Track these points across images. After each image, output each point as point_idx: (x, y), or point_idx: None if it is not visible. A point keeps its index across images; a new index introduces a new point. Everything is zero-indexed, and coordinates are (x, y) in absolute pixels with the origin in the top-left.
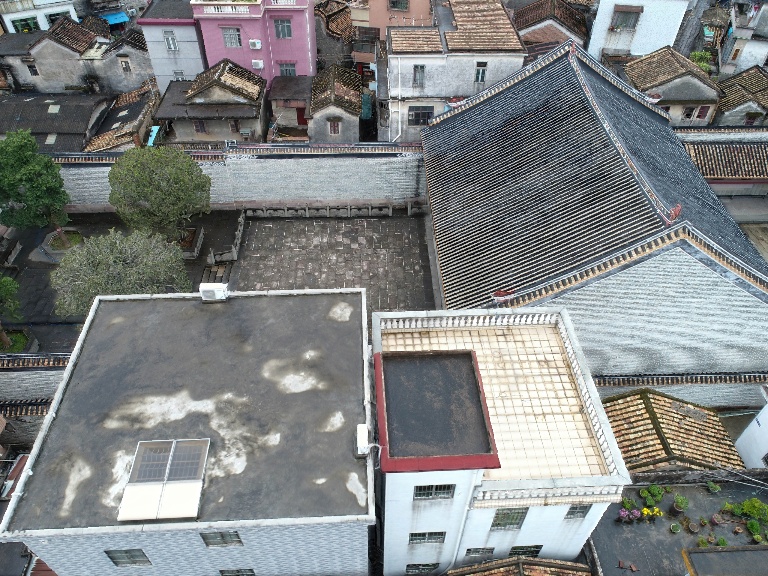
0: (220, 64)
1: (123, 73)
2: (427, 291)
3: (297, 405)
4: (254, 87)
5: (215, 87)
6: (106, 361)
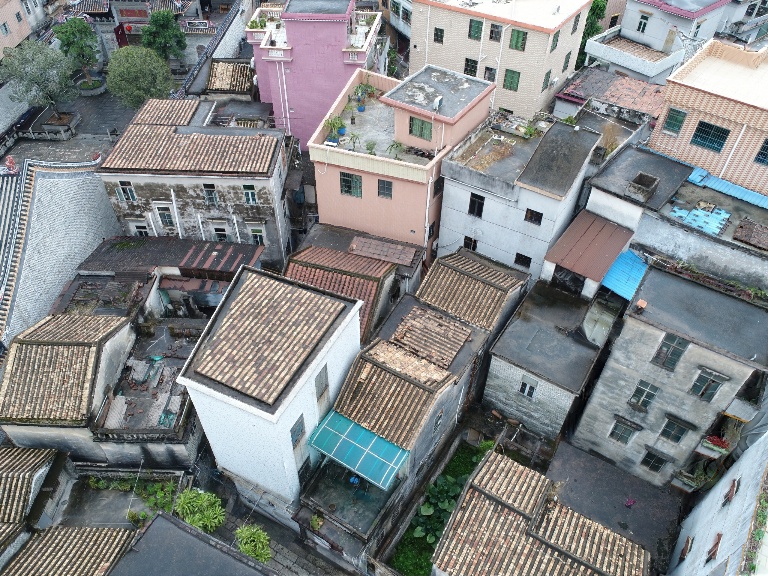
0: None
1: None
2: None
3: None
4: (226, 85)
5: None
6: None
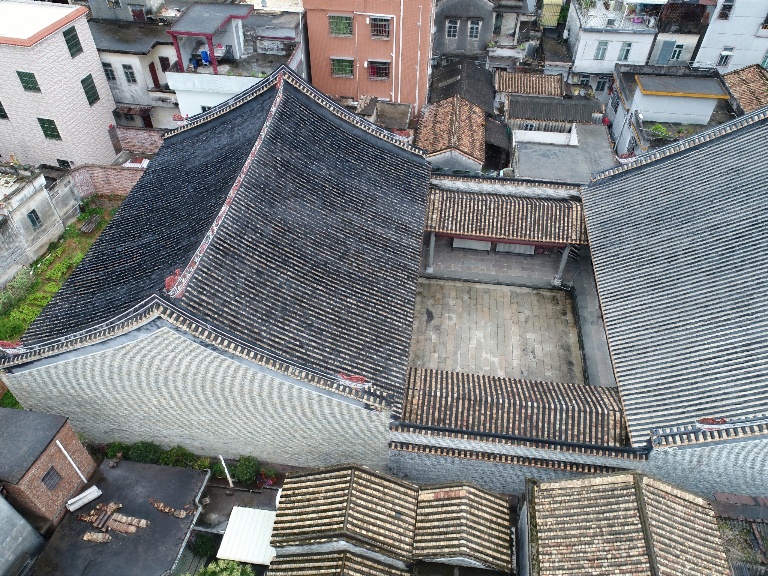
0: None
1: None
2: None
3: None
4: None
5: None
6: None
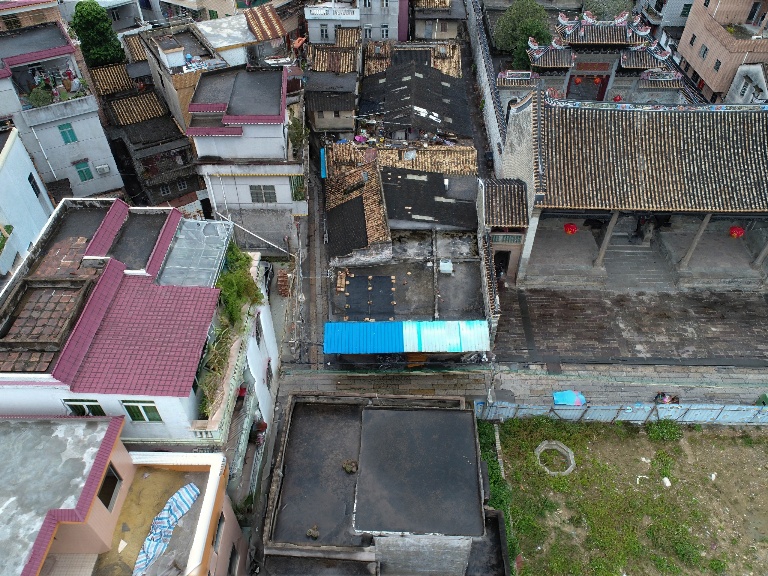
0: None
1: (360, 57)
2: None
3: None
4: None
5: None
6: None
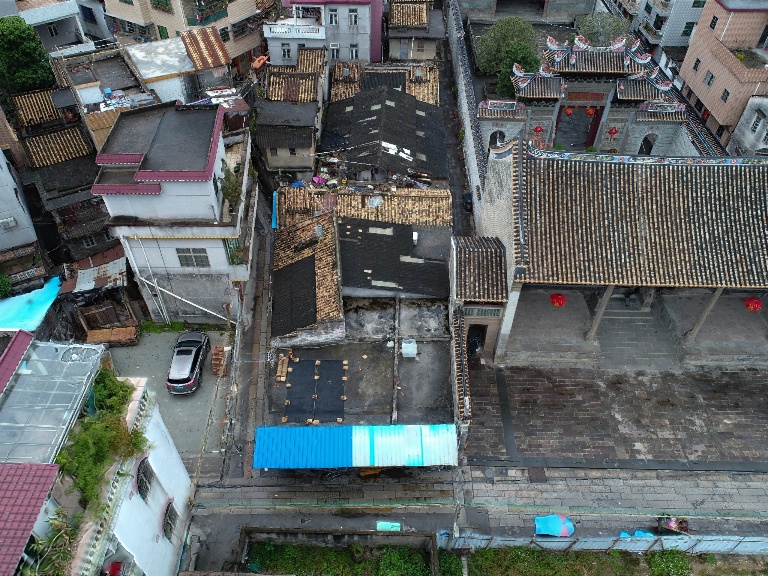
0: (392, 6)
1: None
2: None
3: None
4: None
5: (428, 6)
6: None
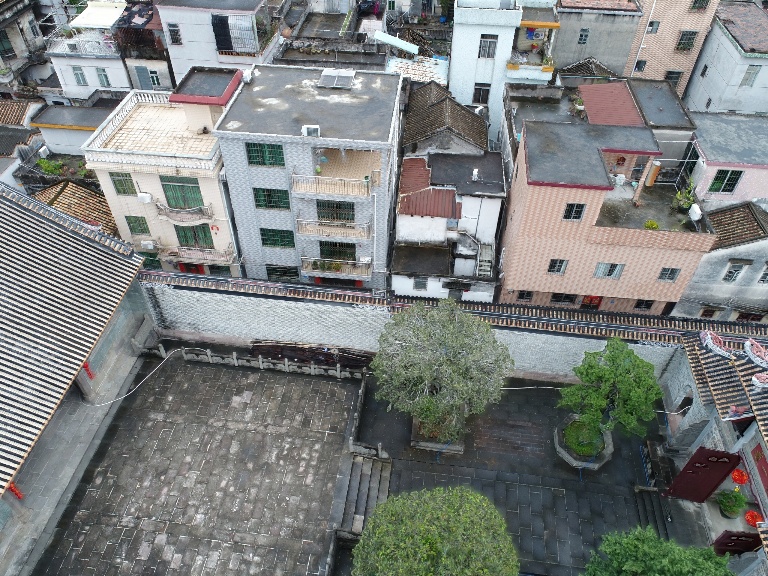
0: None
1: None
2: (110, 440)
3: (274, 94)
4: None
5: None
6: (375, 117)
